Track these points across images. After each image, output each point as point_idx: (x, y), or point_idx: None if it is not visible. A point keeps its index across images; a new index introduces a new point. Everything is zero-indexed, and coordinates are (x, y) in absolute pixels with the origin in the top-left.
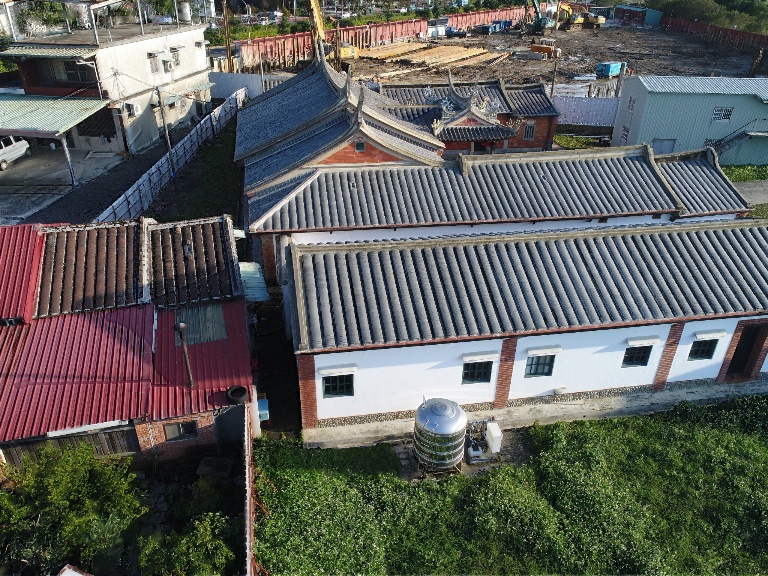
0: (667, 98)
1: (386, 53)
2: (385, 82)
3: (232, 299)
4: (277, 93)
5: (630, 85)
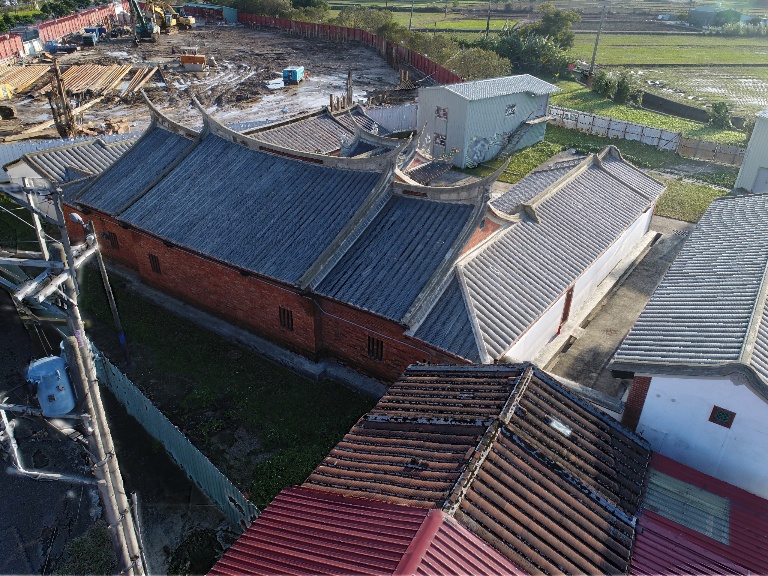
0: (480, 104)
1: (17, 84)
2: (126, 126)
3: (651, 455)
4: (162, 176)
5: (433, 96)
